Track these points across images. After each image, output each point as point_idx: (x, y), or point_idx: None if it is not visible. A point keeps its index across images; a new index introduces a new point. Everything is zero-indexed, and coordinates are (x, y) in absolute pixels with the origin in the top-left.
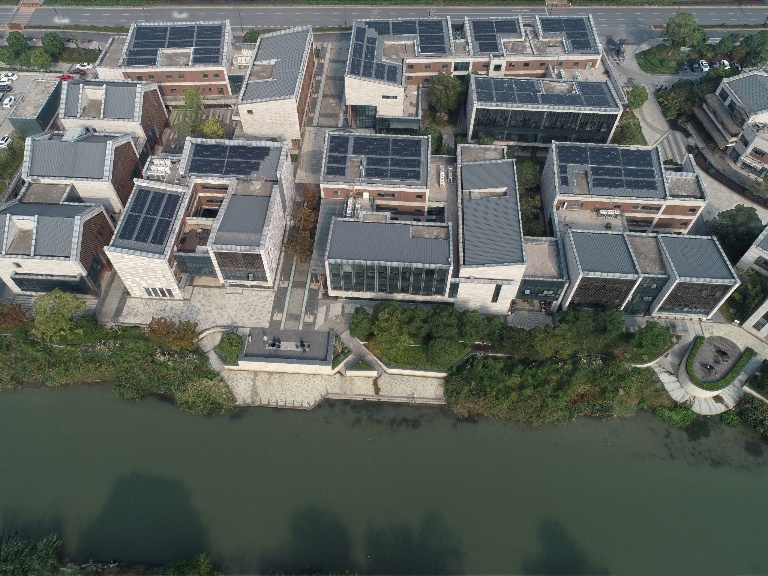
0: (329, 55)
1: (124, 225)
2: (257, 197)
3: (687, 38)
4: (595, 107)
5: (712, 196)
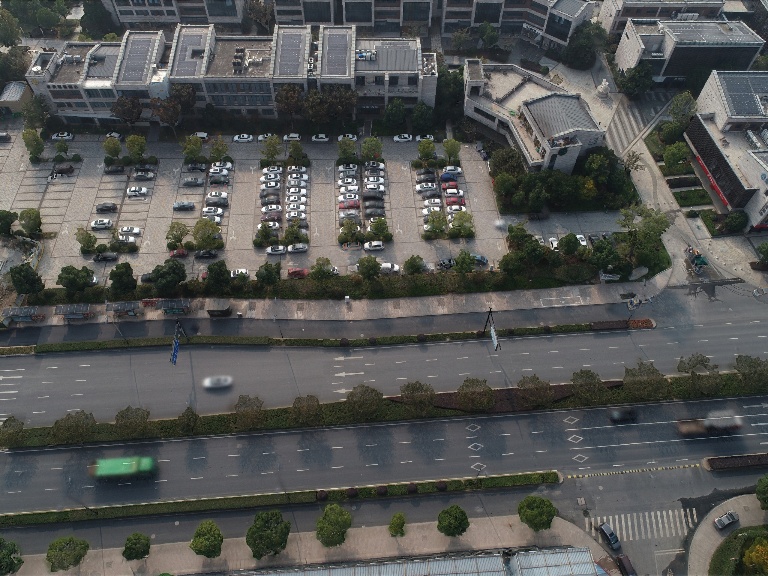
0: None
1: None
2: None
3: (601, 302)
4: (738, 75)
5: (584, 97)
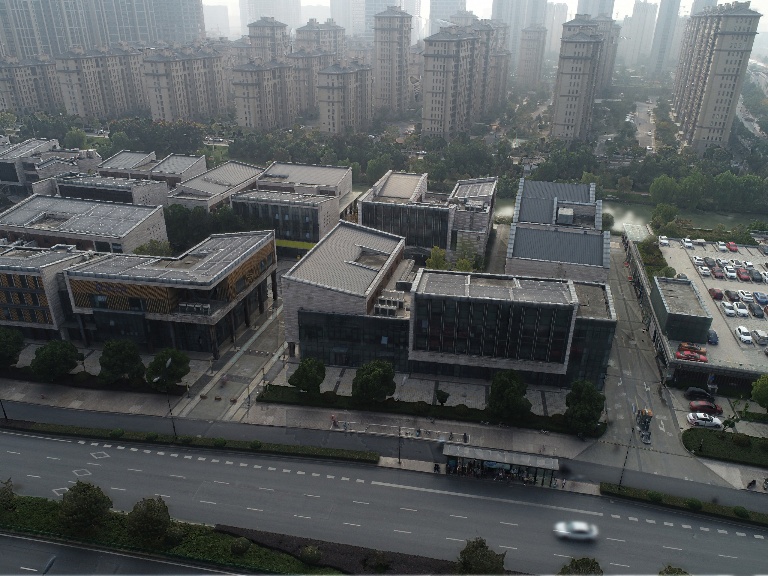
0: (245, 391)
1: (491, 187)
2: (392, 196)
3: None
4: (55, 199)
5: None
